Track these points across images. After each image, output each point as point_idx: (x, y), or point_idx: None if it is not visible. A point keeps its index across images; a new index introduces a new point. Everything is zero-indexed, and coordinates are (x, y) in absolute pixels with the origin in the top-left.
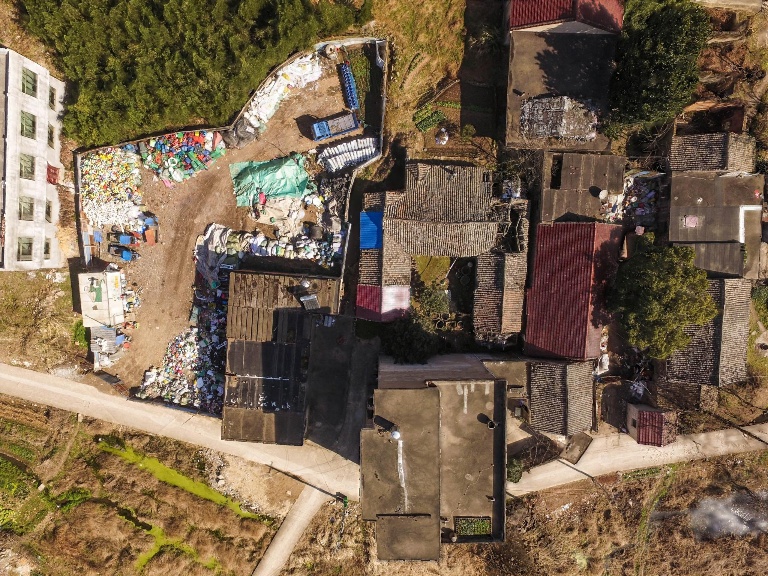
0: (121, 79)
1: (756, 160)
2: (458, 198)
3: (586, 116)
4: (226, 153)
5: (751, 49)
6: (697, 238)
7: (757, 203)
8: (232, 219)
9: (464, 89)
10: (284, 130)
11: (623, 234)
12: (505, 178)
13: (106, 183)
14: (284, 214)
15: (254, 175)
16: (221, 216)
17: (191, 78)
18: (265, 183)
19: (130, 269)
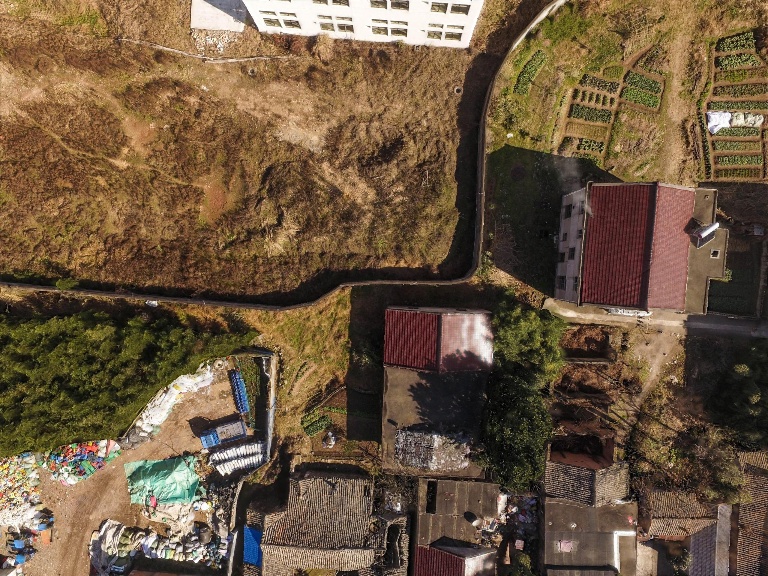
0: (9, 417)
1: (636, 471)
2: (338, 516)
3: (458, 449)
4: (121, 454)
5: (628, 362)
6: (572, 562)
7: (631, 529)
8: (126, 515)
9: (350, 395)
10: (177, 431)
11: (507, 539)
12: (387, 490)
13: (2, 491)
14: (174, 518)
15: (145, 480)
16: (116, 512)
17: (75, 415)
18: (156, 487)
19: (27, 563)
